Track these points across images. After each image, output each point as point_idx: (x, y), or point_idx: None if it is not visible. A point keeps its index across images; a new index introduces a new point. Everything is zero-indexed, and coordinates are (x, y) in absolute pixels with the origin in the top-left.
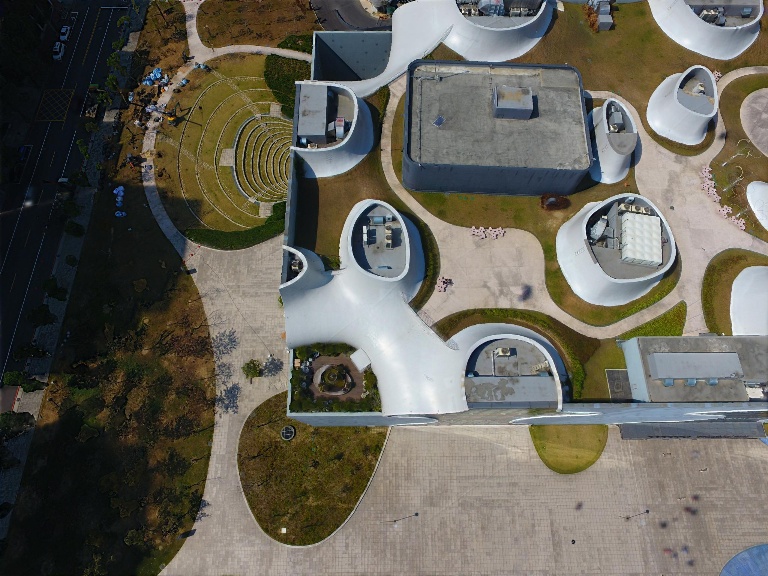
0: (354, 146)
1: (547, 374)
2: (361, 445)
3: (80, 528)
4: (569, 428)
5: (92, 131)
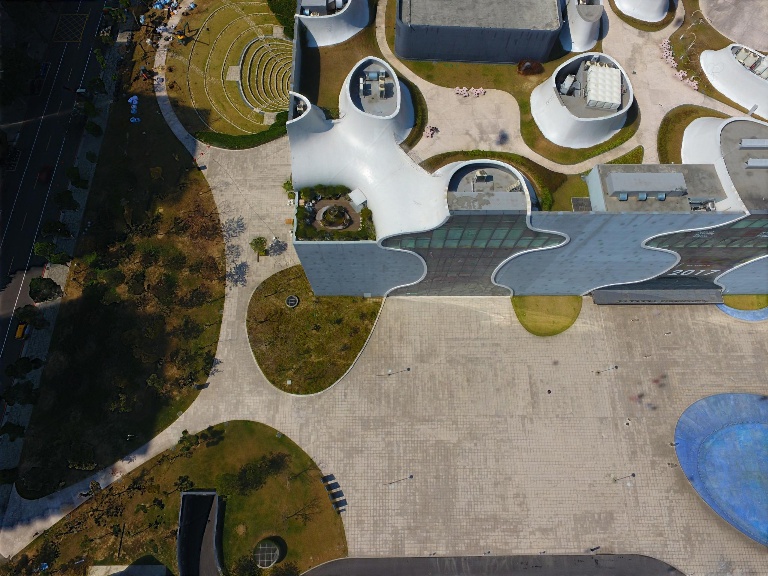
0: (352, 18)
1: None
2: (358, 312)
3: (104, 384)
4: (547, 298)
5: (106, 50)
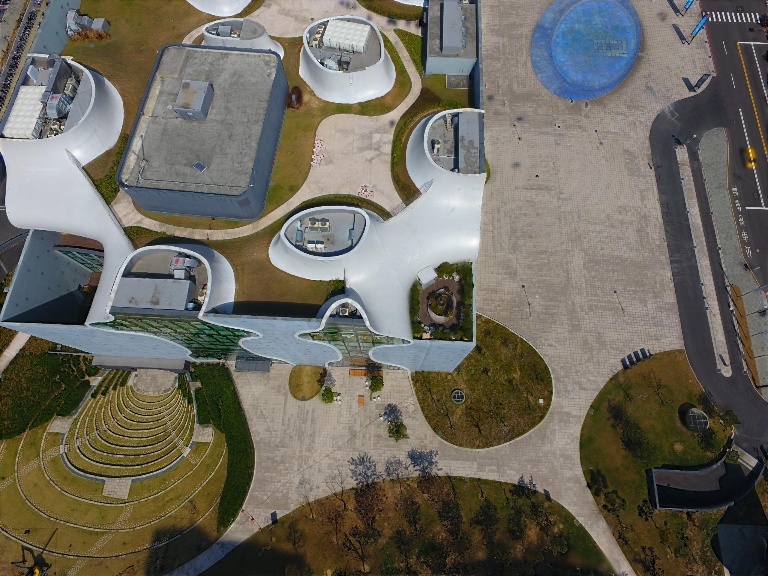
0: None
1: (456, 118)
2: None
3: None
4: None
5: None
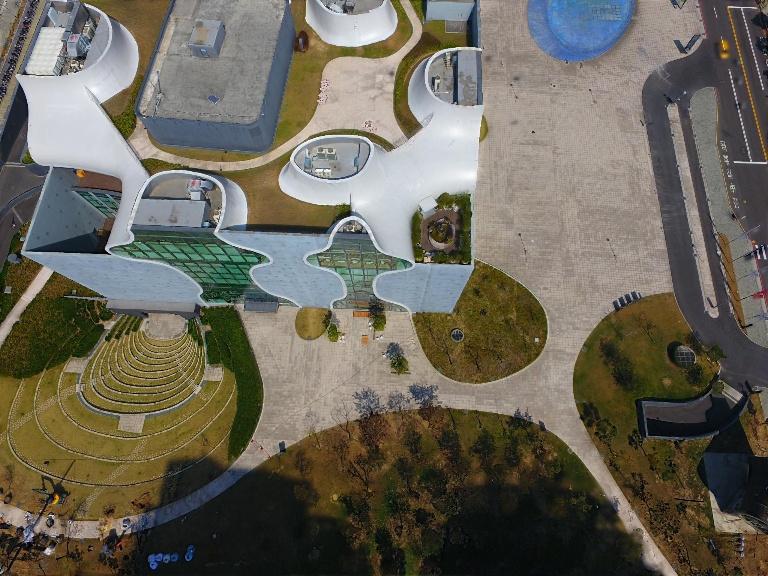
0: None
1: (455, 57)
2: None
3: (543, 544)
4: None
5: None
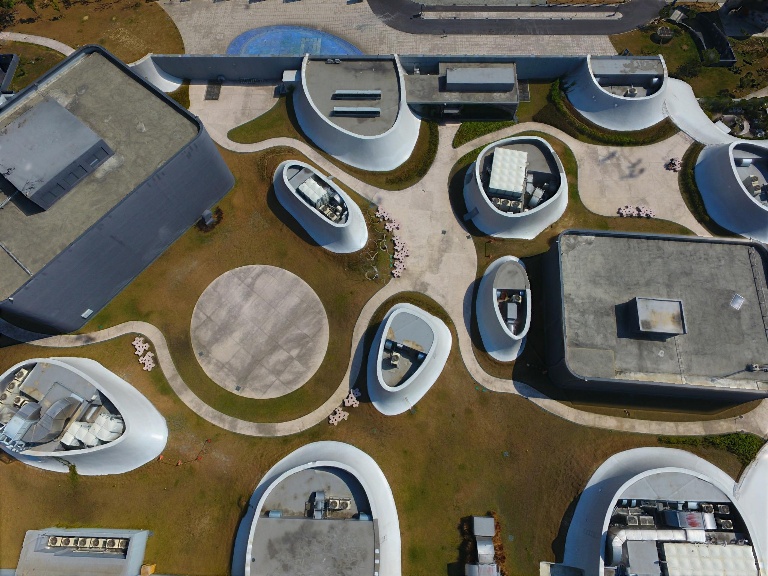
0: None
1: None
2: None
3: None
4: None
5: None
